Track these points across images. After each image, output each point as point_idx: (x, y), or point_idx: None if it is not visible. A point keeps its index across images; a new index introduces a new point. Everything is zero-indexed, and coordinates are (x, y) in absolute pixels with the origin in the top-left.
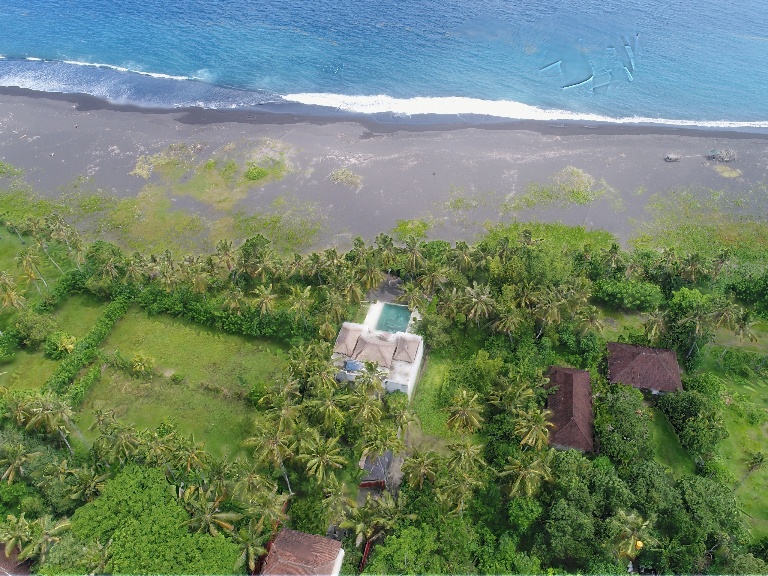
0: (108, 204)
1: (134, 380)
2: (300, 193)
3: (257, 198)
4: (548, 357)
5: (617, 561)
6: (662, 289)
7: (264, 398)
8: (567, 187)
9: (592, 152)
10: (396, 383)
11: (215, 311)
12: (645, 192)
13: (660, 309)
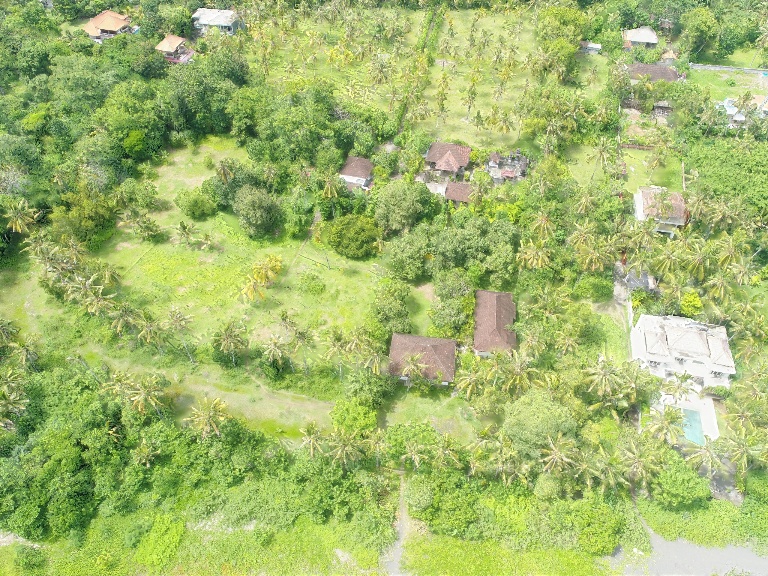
0: None
1: None
2: None
3: None
4: None
5: None
6: None
7: (761, 317)
8: None
9: None
10: None
11: None
12: None
13: None
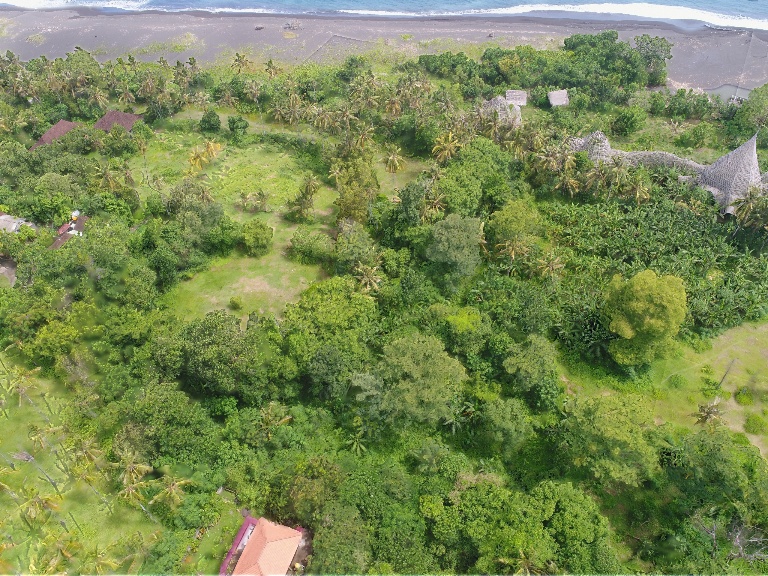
0: None
1: None
2: None
3: None
4: None
5: (2, 184)
6: None
7: None
8: (175, 43)
9: (213, 25)
10: None
11: None
12: (224, 46)
13: None
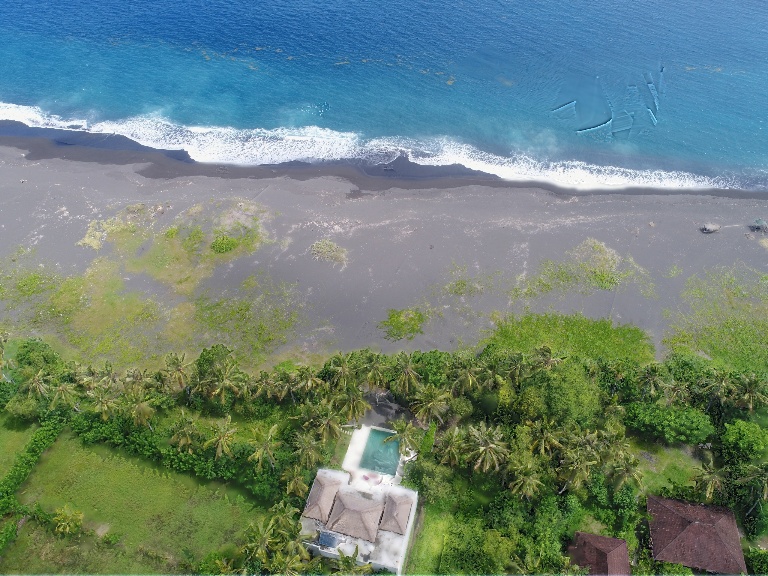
0: (49, 284)
1: (58, 541)
2: (274, 272)
3: (224, 278)
4: None
5: None
6: (709, 411)
7: None
8: (588, 266)
9: (615, 219)
10: (382, 565)
11: (161, 447)
12: (680, 274)
13: (708, 440)
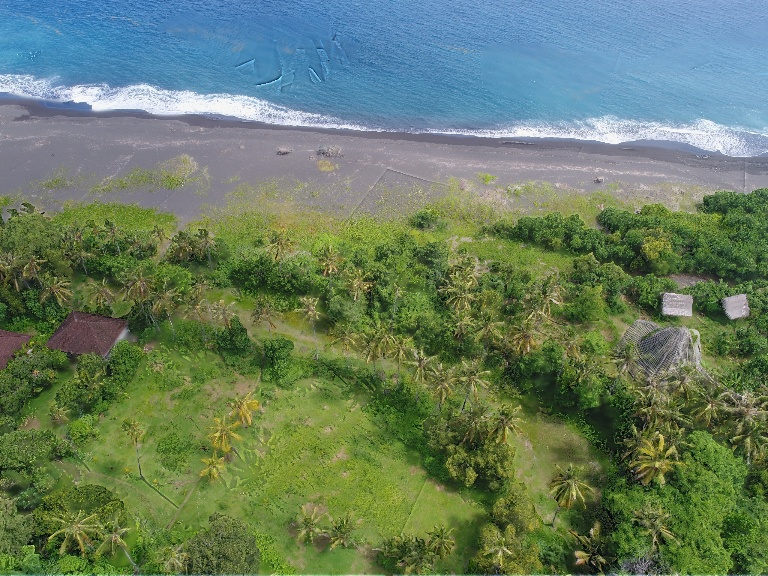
0: None
1: None
2: None
3: None
4: (18, 323)
5: None
6: None
7: None
8: (167, 173)
9: (217, 143)
10: None
11: None
12: (236, 181)
13: None
